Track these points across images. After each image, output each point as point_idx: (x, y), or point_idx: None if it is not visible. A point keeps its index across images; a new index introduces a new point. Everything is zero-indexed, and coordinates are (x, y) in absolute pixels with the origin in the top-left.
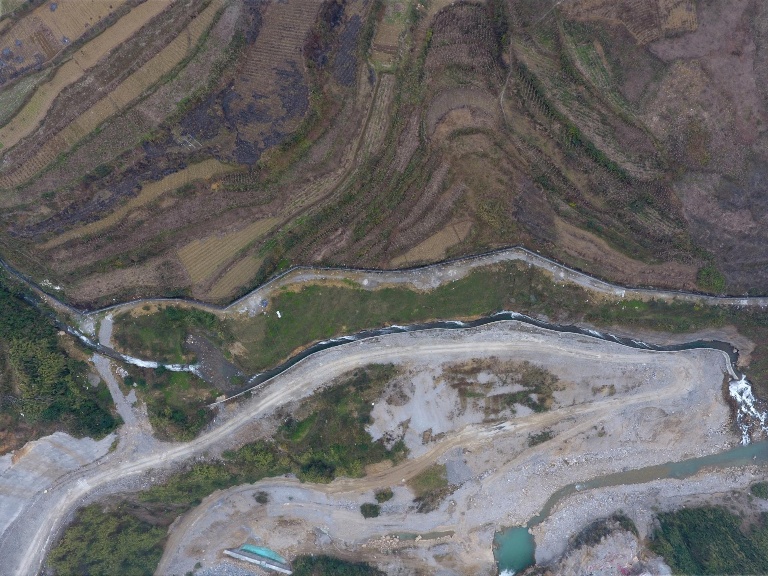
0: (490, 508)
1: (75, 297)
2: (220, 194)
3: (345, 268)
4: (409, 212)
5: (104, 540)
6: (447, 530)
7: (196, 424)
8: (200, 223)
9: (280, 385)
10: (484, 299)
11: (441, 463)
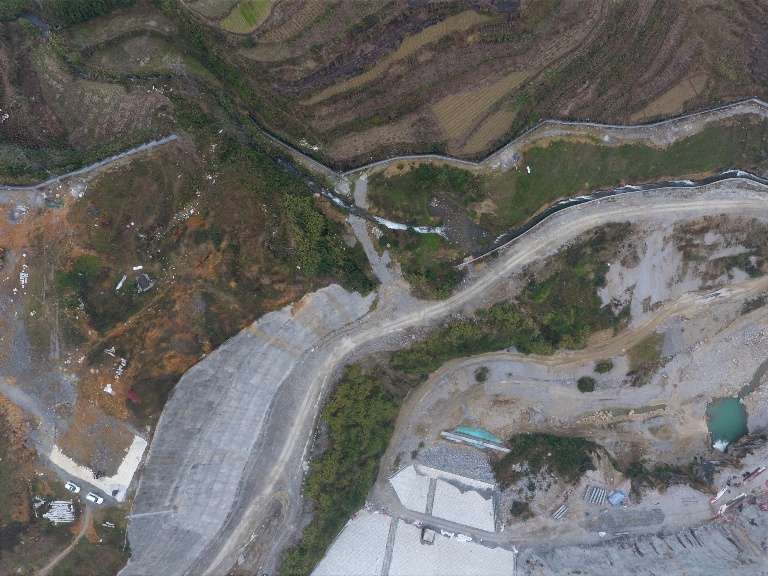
0: (702, 379)
1: (333, 156)
2: (475, 47)
3: (590, 122)
4: (650, 65)
5: (361, 403)
6: (659, 404)
7: (447, 284)
8: (457, 76)
9: (525, 244)
10: (717, 154)
11: (660, 331)
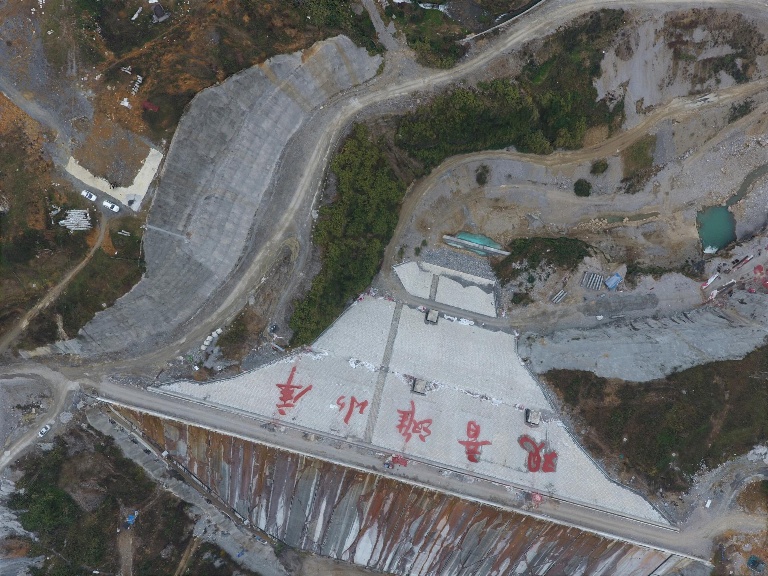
0: (692, 187)
1: None
2: None
3: None
4: None
5: (368, 169)
6: (652, 212)
7: (450, 57)
8: None
9: (524, 24)
10: None
11: (652, 133)
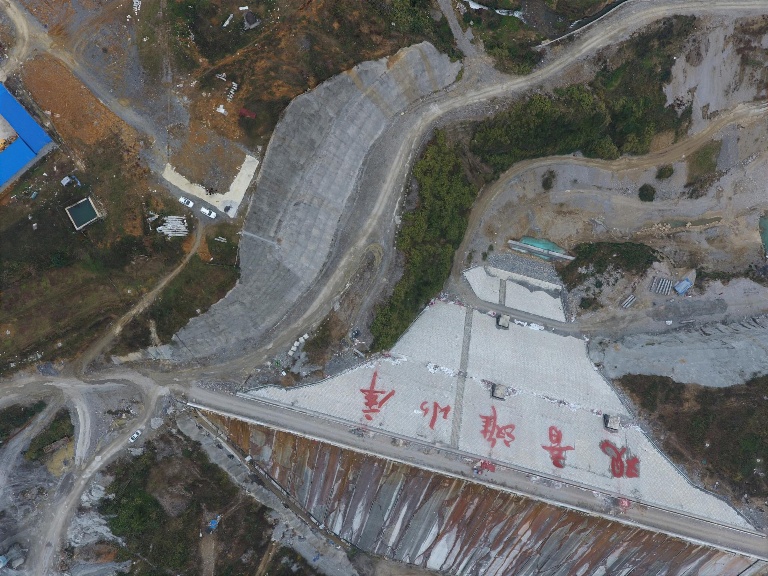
0: (755, 192)
1: None
2: None
3: None
4: None
5: (445, 175)
6: (714, 216)
7: (527, 63)
8: None
9: (599, 30)
10: None
11: (718, 139)
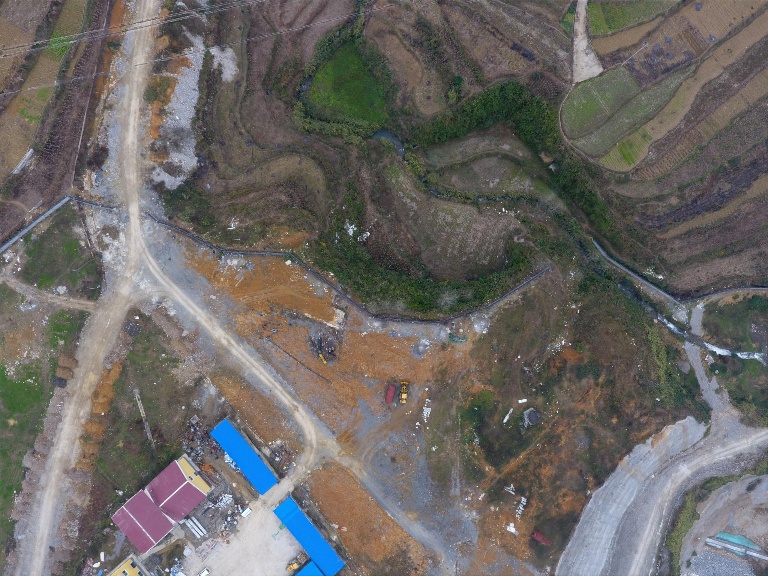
0: None
1: (677, 286)
2: None
3: None
4: None
5: None
6: None
7: (767, 410)
8: None
9: None
10: None
11: None
